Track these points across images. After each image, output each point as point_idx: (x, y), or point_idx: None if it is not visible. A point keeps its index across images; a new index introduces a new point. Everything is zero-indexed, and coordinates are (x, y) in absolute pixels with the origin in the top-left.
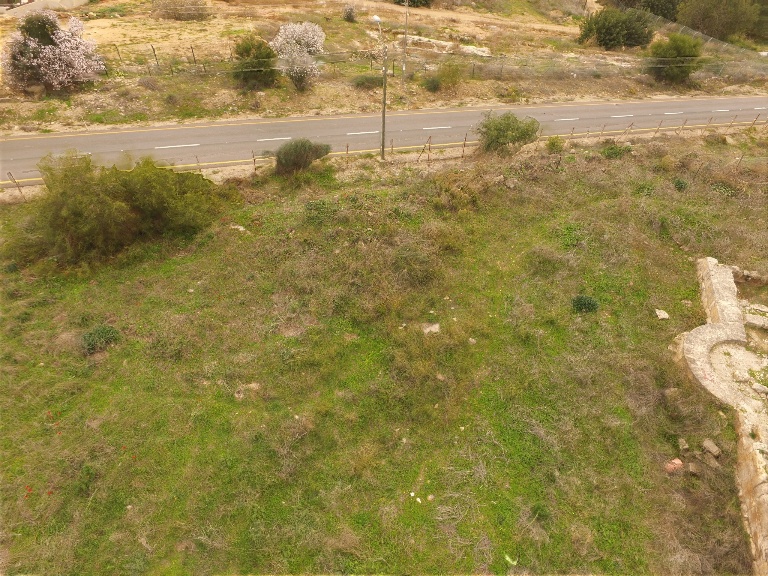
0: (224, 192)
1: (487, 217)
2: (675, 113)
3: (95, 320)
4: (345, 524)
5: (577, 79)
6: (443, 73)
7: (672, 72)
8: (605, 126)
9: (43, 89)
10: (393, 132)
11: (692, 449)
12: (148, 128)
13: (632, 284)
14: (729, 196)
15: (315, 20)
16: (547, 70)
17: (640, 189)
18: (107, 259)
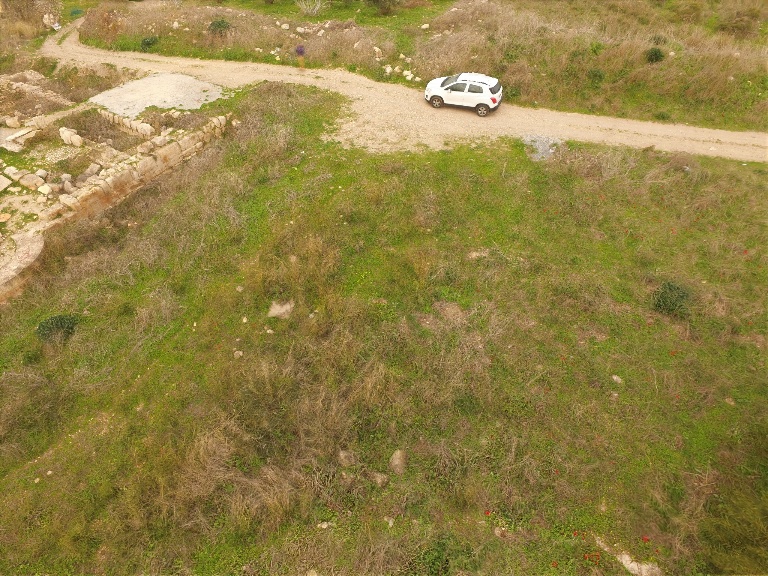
0: None
1: None
2: None
3: None
4: None
5: None
6: None
7: None
8: None
9: None
10: None
11: (110, 229)
12: None
13: None
14: None
15: None
16: None
17: None
18: None
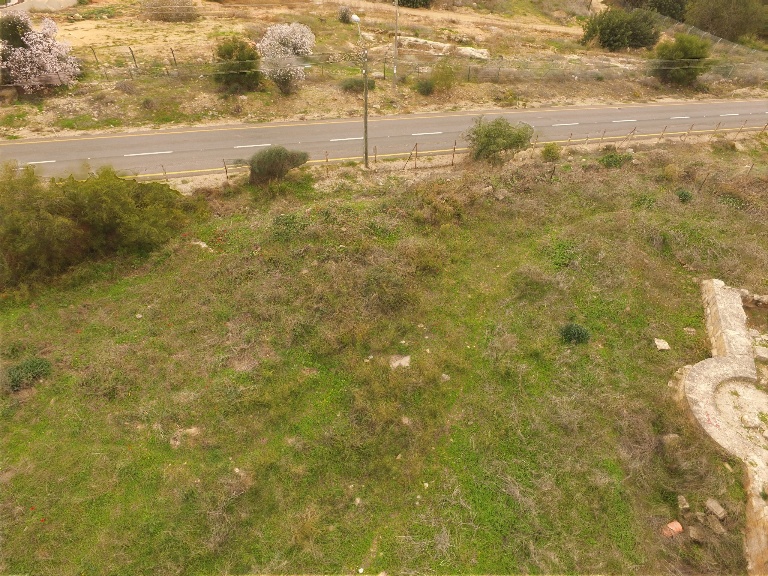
0: (192, 204)
1: (472, 232)
2: (681, 117)
3: (27, 350)
4: None
5: (578, 82)
6: (436, 76)
7: (678, 74)
8: (605, 132)
9: (14, 93)
10: (380, 138)
11: (693, 509)
12: (120, 134)
13: (629, 309)
14: (738, 209)
15: (309, 21)
16: (547, 72)
17: (641, 201)
18: (51, 280)
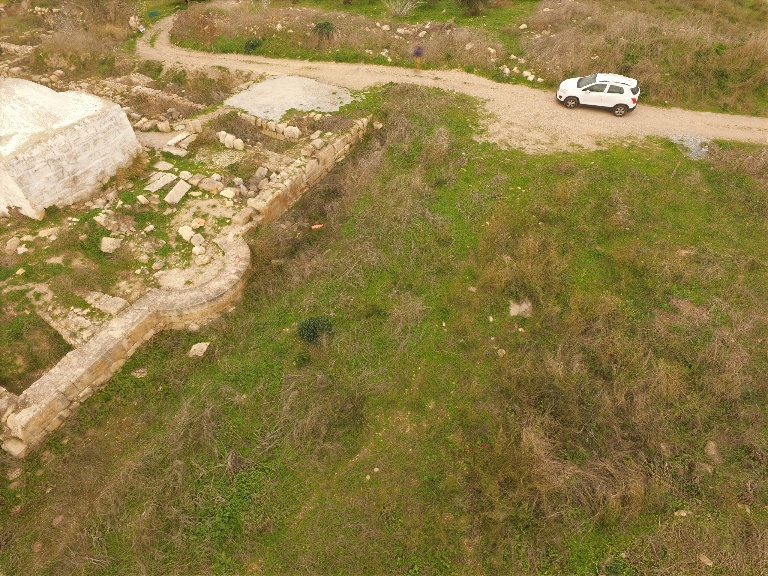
0: None
1: None
2: None
3: None
4: (564, 179)
5: None
6: None
7: None
8: None
9: None
10: None
11: (296, 232)
12: None
13: None
14: None
15: None
16: None
17: None
18: None
